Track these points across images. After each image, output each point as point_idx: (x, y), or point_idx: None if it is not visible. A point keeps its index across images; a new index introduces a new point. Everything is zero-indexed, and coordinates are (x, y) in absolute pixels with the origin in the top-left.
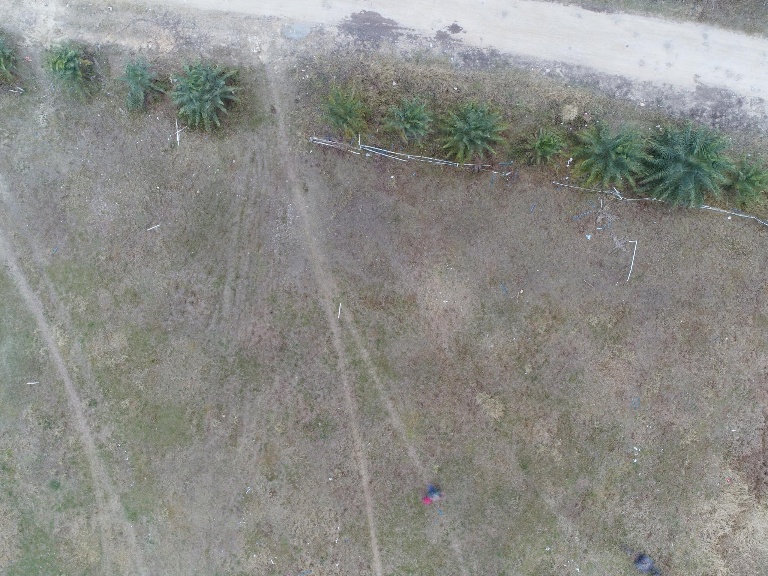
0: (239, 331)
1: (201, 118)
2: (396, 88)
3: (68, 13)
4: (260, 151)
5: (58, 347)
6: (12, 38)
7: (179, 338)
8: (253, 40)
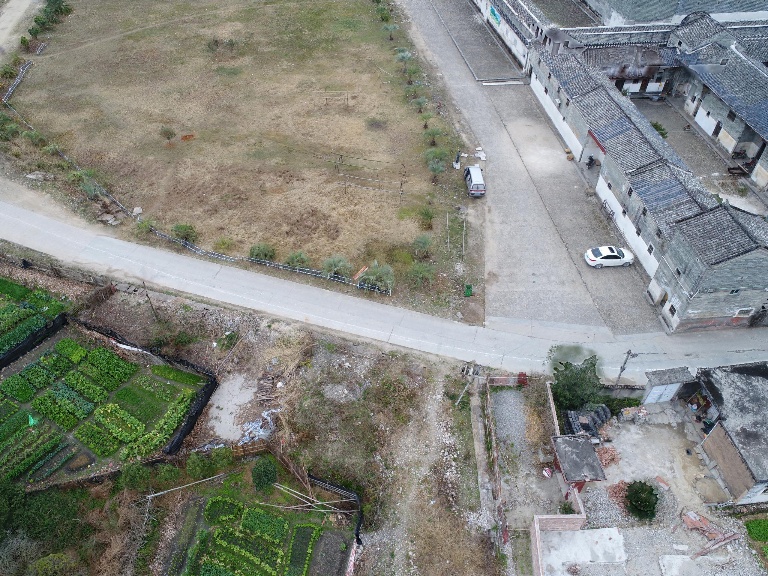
0: (148, 1)
1: None
2: None
3: (18, 33)
4: (81, 4)
5: (156, 24)
6: None
7: (151, 8)
8: (38, 7)
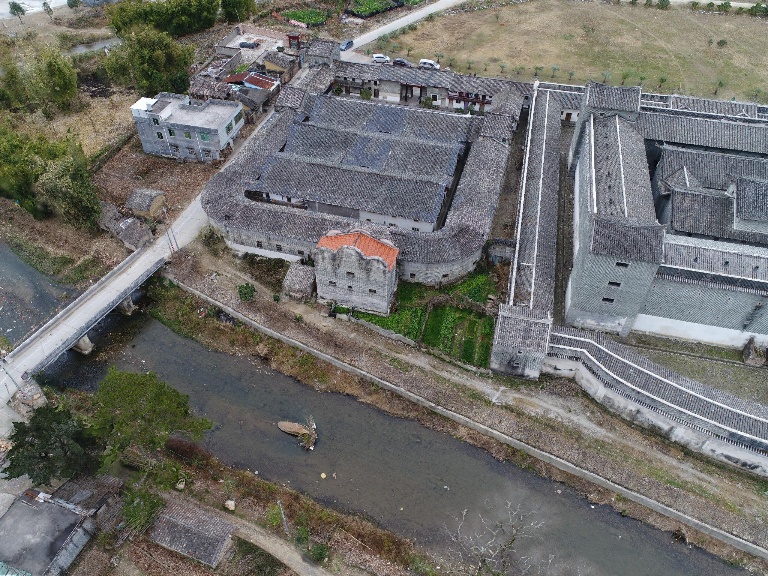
0: None
1: (663, 6)
2: (703, 7)
3: None
4: None
5: None
6: (617, 0)
7: None
8: None
